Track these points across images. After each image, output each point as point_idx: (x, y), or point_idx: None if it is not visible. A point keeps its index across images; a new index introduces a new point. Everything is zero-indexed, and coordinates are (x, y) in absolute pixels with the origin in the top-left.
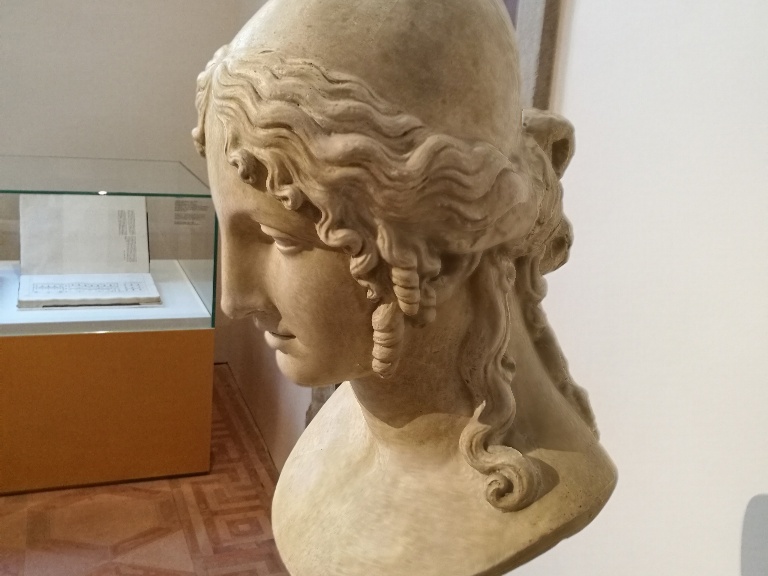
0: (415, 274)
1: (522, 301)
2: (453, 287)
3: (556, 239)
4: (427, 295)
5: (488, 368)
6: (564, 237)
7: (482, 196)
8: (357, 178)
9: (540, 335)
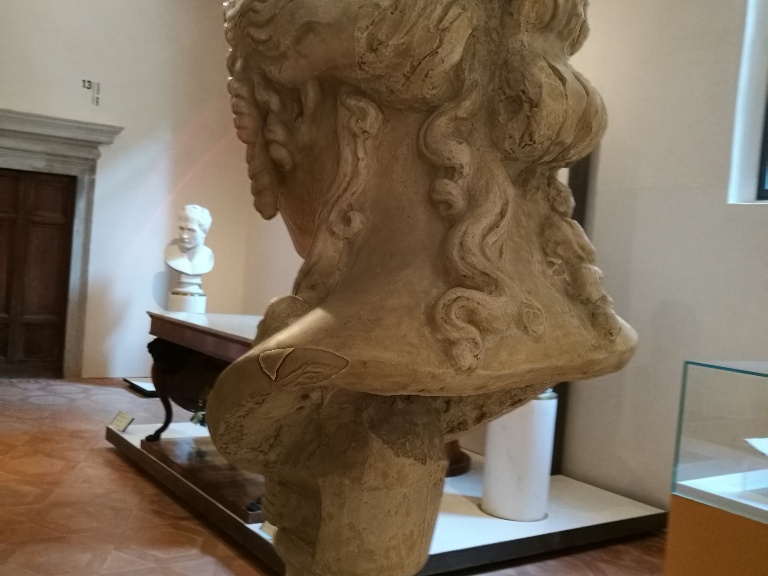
0: (238, 101)
1: (430, 168)
2: (306, 128)
3: (515, 100)
4: (268, 129)
5: (321, 215)
6: (520, 94)
7: (271, 18)
8: (225, 31)
9: (456, 217)
